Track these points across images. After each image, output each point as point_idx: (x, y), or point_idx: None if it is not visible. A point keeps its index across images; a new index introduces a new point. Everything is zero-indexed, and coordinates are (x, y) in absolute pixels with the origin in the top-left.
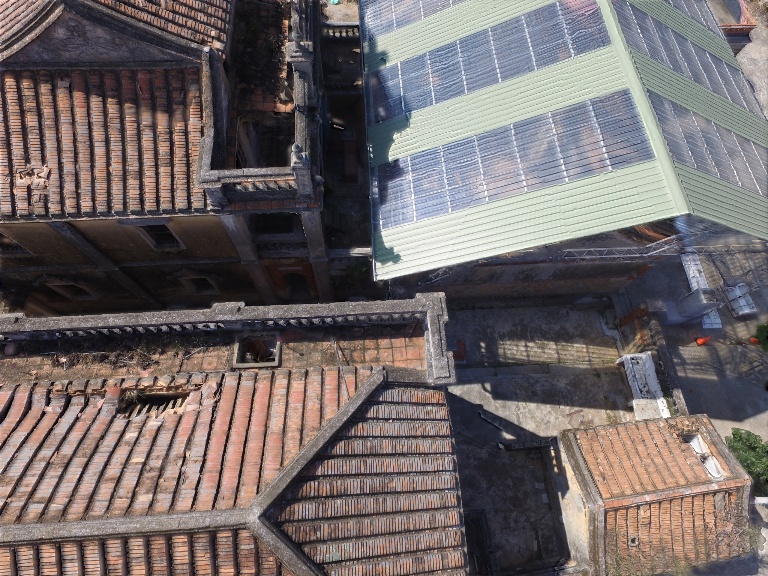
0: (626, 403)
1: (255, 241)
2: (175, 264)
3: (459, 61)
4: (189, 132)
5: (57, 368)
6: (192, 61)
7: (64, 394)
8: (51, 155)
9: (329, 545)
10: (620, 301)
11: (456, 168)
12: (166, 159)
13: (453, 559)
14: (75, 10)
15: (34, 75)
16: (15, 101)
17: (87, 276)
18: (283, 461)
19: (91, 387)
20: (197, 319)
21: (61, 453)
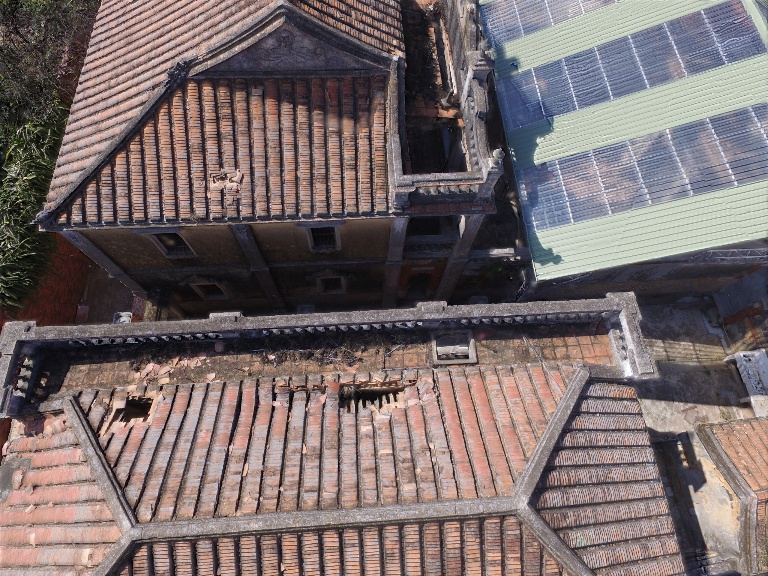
0: (738, 399)
1: (405, 242)
2: (322, 264)
3: (600, 67)
4: (372, 138)
5: (267, 365)
6: (381, 70)
7: (289, 389)
8: (244, 160)
9: (577, 531)
10: (721, 300)
11: (611, 172)
12: (351, 164)
13: (670, 546)
14: (293, 22)
15: (230, 83)
16: (212, 108)
17: (232, 276)
18: (524, 452)
19: (312, 383)
20: (407, 318)
21: (310, 445)
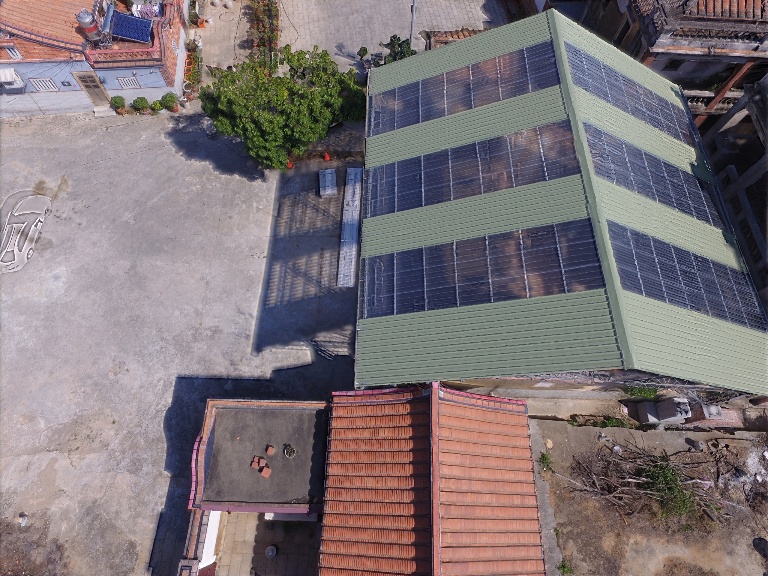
0: None
1: None
2: None
3: None
4: None
5: None
6: None
7: None
8: None
9: None
10: None
11: None
12: None
13: None
14: None
15: None
16: None
17: None
18: None
19: None
20: None
21: None
